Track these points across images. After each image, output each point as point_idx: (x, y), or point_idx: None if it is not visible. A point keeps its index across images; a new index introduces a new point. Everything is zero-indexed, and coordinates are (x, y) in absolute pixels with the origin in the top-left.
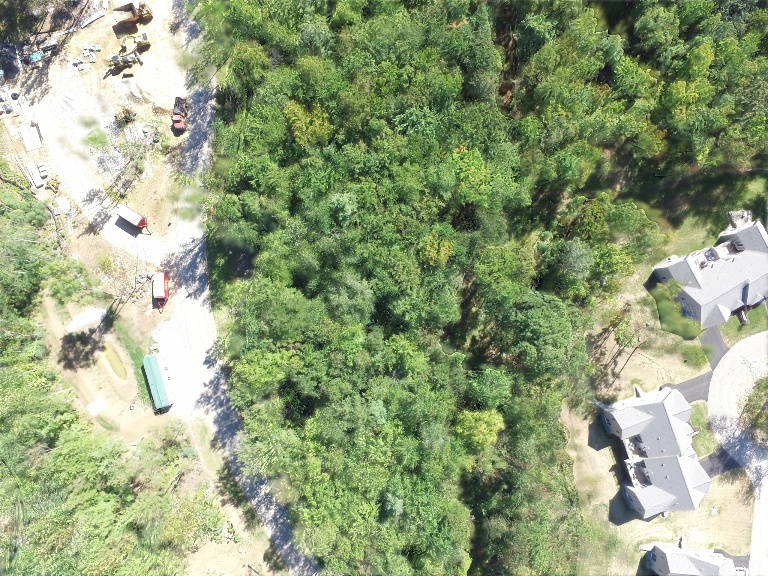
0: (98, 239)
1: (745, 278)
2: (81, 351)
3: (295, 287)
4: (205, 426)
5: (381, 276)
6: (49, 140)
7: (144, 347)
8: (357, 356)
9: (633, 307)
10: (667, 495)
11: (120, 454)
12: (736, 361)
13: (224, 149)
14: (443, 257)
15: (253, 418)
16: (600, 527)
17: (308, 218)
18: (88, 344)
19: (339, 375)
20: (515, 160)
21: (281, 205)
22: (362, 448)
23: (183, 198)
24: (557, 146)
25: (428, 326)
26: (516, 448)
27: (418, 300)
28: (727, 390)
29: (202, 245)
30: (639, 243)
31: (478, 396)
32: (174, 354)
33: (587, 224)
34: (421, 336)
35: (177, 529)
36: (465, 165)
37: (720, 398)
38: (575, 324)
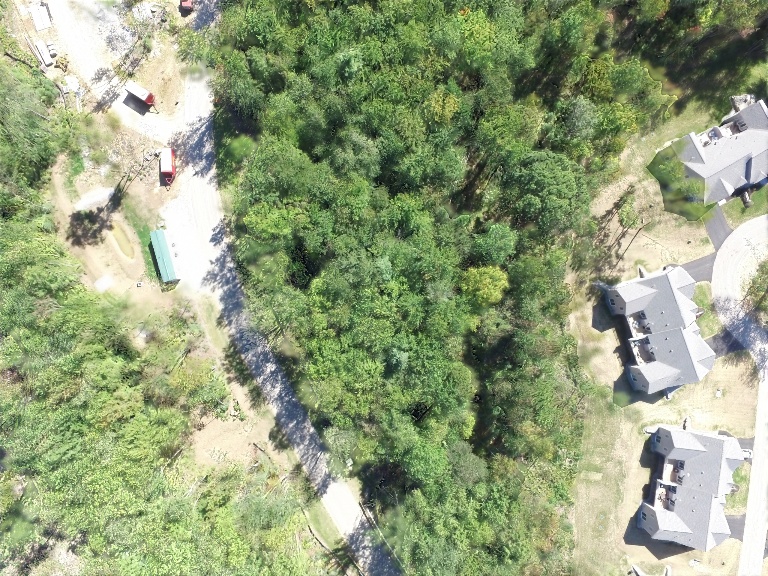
0: (106, 117)
1: (748, 152)
2: (89, 229)
3: (301, 149)
4: (211, 304)
5: (386, 134)
6: (59, 20)
7: (151, 224)
8: (363, 211)
9: (637, 189)
10: (671, 369)
11: (127, 329)
12: (740, 243)
13: (231, 30)
14: (448, 114)
15: (259, 297)
16: (604, 409)
17: (314, 74)
18: (96, 222)
19: (345, 231)
20: (519, 21)
21: (288, 63)
22: (367, 303)
23: (190, 77)
24: (561, 9)
25: (433, 185)
26: (520, 309)
27: (423, 156)
28: (731, 272)
29: (209, 124)
30: (642, 104)
31: (483, 249)
32: (181, 231)
33: (591, 80)
34: (426, 194)
35: (183, 406)
36: (469, 25)
37: (724, 279)
38: (579, 181)
